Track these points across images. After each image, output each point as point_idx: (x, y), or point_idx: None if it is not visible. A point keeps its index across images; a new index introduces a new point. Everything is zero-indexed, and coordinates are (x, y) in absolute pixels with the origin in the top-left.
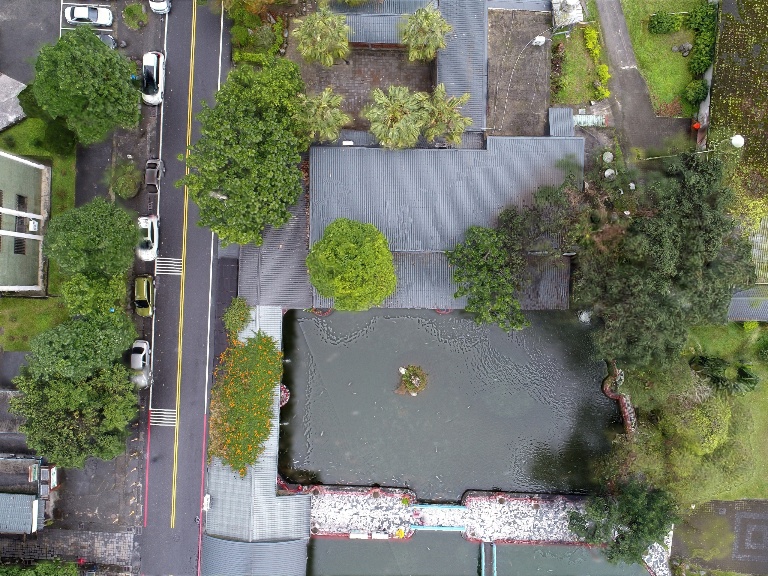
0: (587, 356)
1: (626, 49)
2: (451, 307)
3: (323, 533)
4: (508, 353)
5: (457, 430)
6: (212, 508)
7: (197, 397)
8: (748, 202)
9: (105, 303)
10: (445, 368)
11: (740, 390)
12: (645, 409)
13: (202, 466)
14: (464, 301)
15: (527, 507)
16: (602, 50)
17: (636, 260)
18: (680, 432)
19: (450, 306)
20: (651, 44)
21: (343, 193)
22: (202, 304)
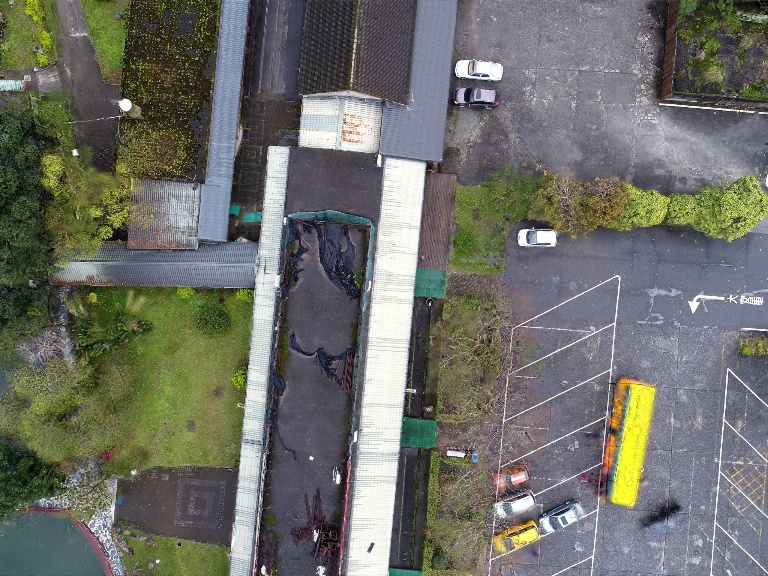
0: None
1: (77, 17)
2: None
3: None
4: None
5: None
6: None
7: None
8: (49, 160)
9: None
10: None
11: (97, 351)
12: None
13: None
14: None
15: None
16: (53, 17)
17: None
18: None
19: None
20: (99, 12)
21: None
22: None
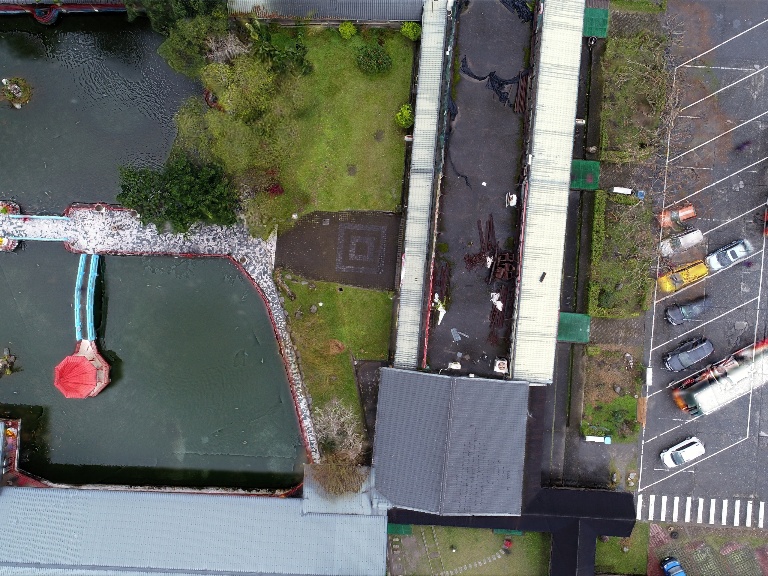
0: None
1: None
2: (31, 1)
3: None
4: (118, 69)
5: (66, 146)
6: None
7: None
8: None
9: None
10: (53, 83)
11: None
12: None
13: None
14: None
15: (130, 219)
16: None
17: None
18: (208, 88)
19: (30, 1)
20: None
21: None
22: None
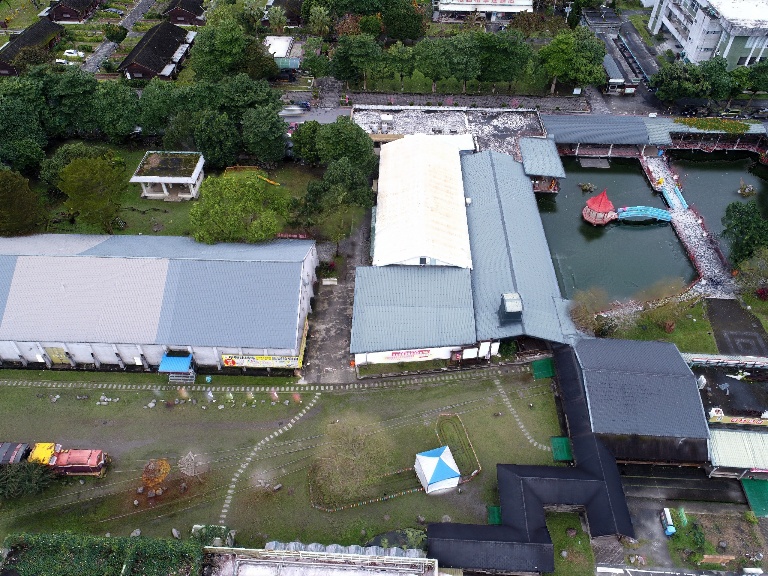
0: None
1: None
2: None
3: (642, 162)
4: None
5: None
6: None
7: None
8: None
9: (740, 80)
10: None
11: None
12: None
13: None
14: None
15: (700, 233)
16: None
17: None
18: None
19: None
20: None
21: None
22: None
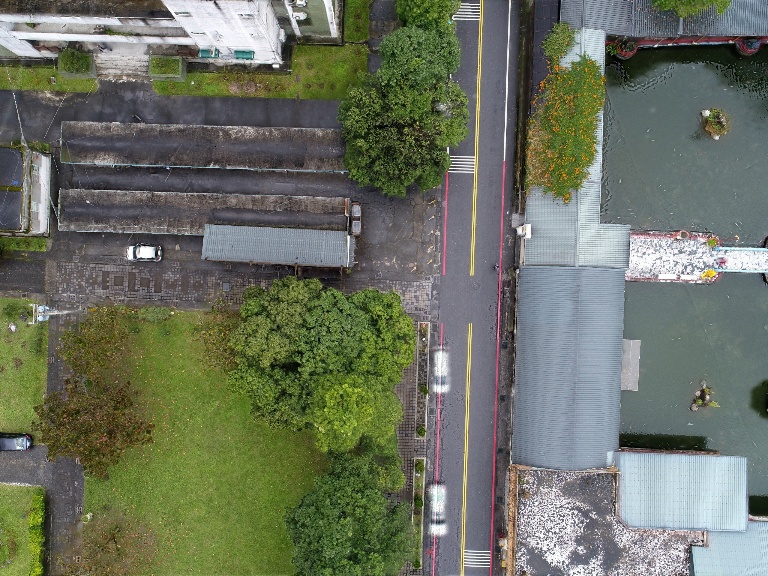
0: None
1: None
2: None
3: (626, 278)
4: None
5: (757, 176)
6: (532, 238)
7: (496, 143)
8: None
9: (445, 13)
10: (745, 114)
11: None
12: None
13: (501, 213)
14: None
15: None
16: None
17: None
18: None
19: None
20: None
21: None
22: (500, 49)
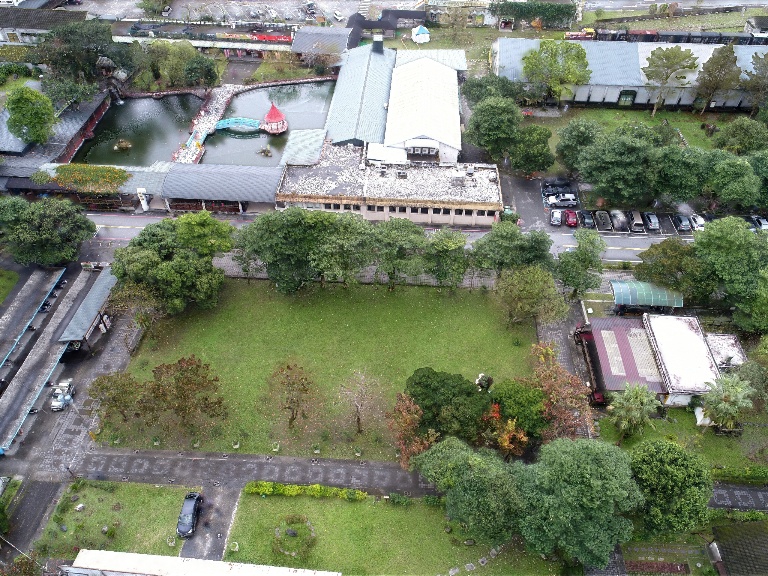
0: (142, 105)
1: None
2: (85, 121)
3: None
4: None
5: None
6: (147, 191)
7: None
8: None
9: None
10: None
11: None
12: (150, 61)
13: (132, 217)
14: (84, 117)
15: None
16: None
17: (72, 38)
18: (159, 49)
19: (84, 121)
20: (8, 86)
21: (0, 142)
22: None
